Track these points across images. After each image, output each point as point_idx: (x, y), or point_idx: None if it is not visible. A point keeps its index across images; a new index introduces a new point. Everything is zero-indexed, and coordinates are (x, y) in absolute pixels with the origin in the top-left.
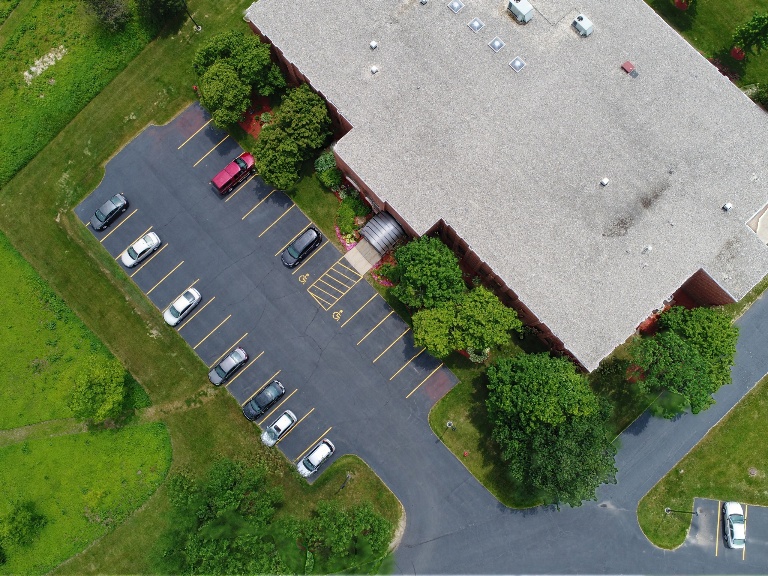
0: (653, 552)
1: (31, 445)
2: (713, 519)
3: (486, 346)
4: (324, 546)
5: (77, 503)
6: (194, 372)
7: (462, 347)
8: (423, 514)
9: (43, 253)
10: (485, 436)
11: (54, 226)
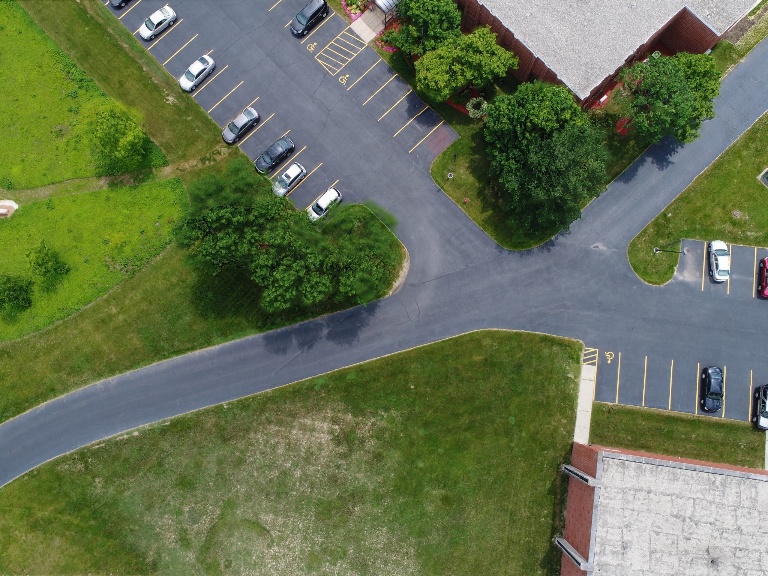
0: (643, 288)
1: (54, 201)
2: (699, 258)
3: (484, 77)
4: (332, 285)
5: (98, 253)
6: (208, 133)
7: (462, 82)
8: (426, 256)
9: (65, 30)
10: (484, 185)
11: (75, 6)
